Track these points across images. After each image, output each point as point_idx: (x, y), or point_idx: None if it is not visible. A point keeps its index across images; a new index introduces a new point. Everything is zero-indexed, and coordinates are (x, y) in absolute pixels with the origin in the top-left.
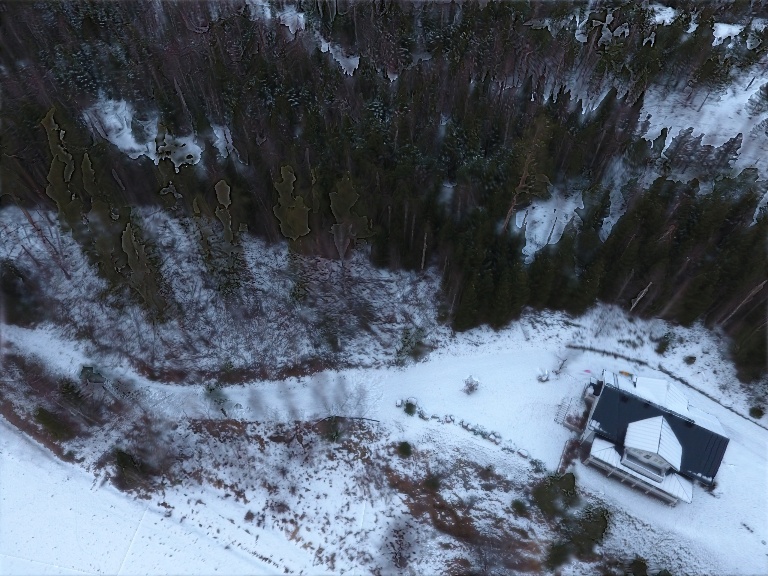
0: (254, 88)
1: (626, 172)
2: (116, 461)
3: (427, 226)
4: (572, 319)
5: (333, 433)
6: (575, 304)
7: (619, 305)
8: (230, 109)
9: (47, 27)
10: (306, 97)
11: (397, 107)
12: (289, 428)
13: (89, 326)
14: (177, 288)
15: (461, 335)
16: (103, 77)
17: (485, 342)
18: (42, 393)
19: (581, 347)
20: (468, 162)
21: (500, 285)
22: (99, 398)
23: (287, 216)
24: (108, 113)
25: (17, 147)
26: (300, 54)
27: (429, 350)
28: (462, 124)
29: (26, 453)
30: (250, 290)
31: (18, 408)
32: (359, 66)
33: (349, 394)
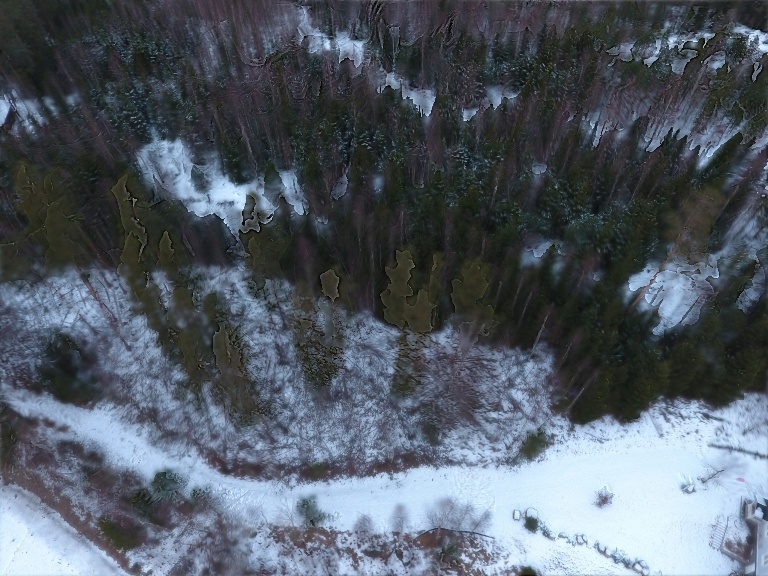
0: (326, 133)
1: (761, 232)
2: (188, 575)
3: (544, 303)
4: (712, 411)
5: (438, 549)
6: (720, 396)
7: (767, 394)
8: (299, 156)
9: (96, 62)
10: (381, 141)
11: (487, 155)
12: (386, 541)
13: (153, 407)
14: (249, 363)
15: (581, 428)
16: (158, 117)
17: (611, 438)
18: (103, 488)
19: (727, 447)
20: (573, 219)
21: (634, 376)
22: (167, 496)
23: (404, 310)
24: (163, 156)
25: (73, 202)
26: (372, 93)
27: (544, 446)
28: (565, 176)
29: (87, 563)
30: (331, 368)
31: (77, 506)
32: (435, 105)
33: (454, 499)
